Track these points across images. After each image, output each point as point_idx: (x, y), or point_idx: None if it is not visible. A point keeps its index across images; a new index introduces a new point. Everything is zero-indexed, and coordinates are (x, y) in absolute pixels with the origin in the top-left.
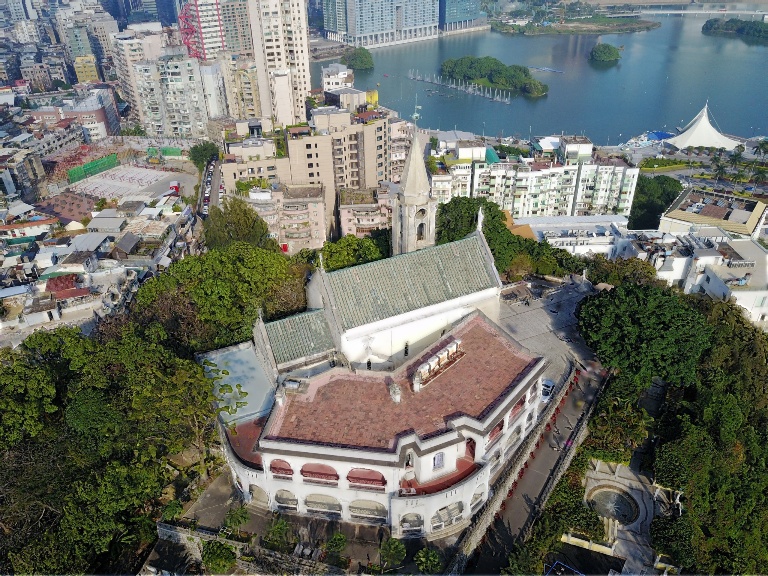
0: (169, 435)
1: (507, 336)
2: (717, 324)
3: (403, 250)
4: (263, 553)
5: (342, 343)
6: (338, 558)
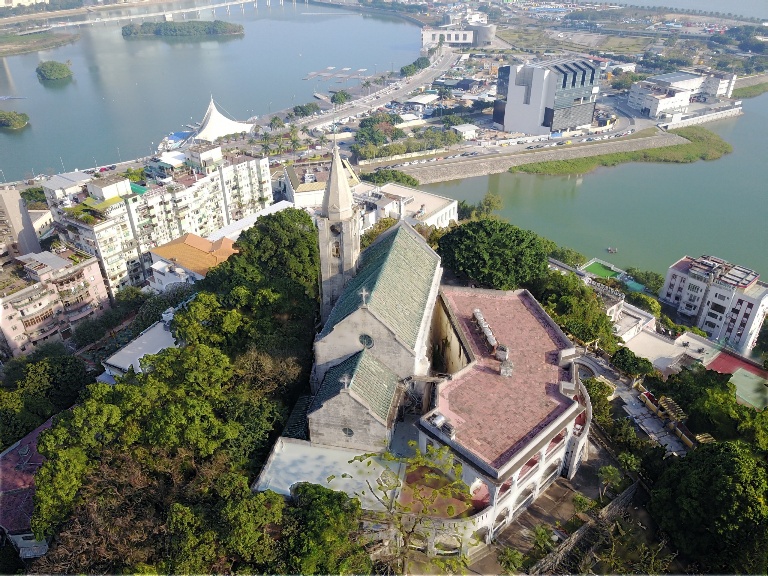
0: (361, 567)
1: (486, 291)
2: None
3: (346, 268)
4: (532, 573)
5: (415, 365)
6: (570, 522)
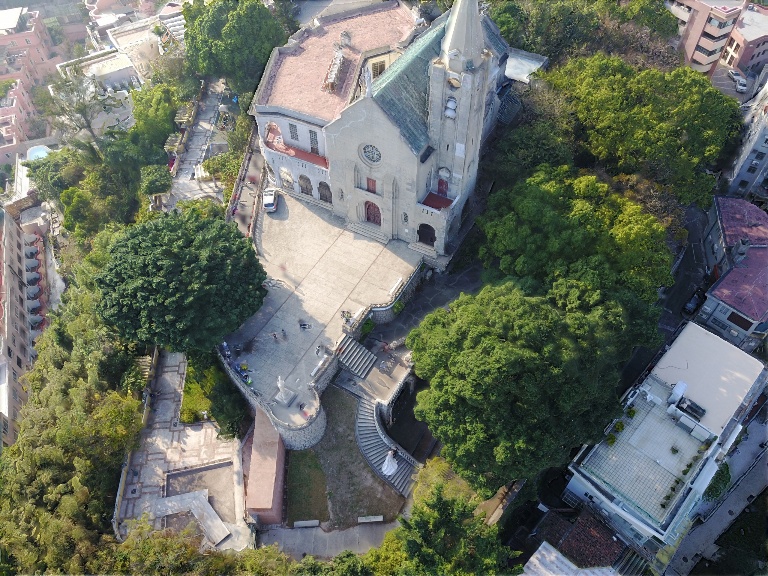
0: None
1: None
2: (77, 427)
3: None
4: None
5: None
6: None
